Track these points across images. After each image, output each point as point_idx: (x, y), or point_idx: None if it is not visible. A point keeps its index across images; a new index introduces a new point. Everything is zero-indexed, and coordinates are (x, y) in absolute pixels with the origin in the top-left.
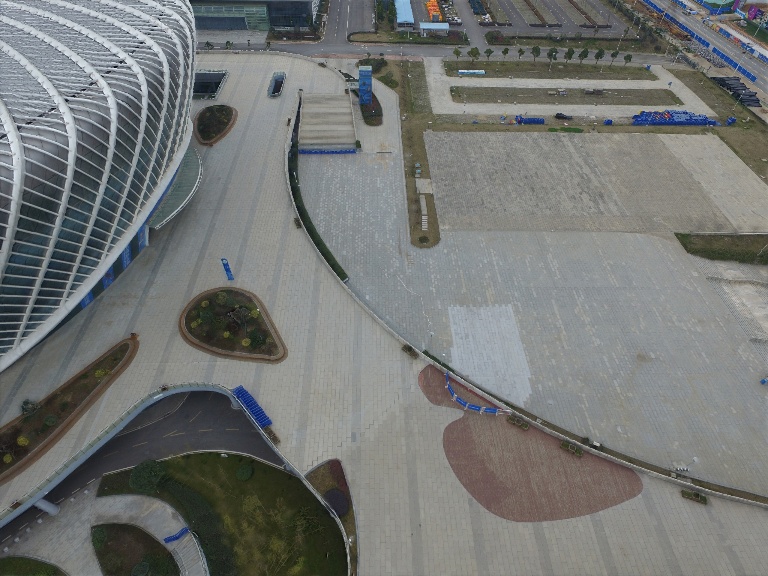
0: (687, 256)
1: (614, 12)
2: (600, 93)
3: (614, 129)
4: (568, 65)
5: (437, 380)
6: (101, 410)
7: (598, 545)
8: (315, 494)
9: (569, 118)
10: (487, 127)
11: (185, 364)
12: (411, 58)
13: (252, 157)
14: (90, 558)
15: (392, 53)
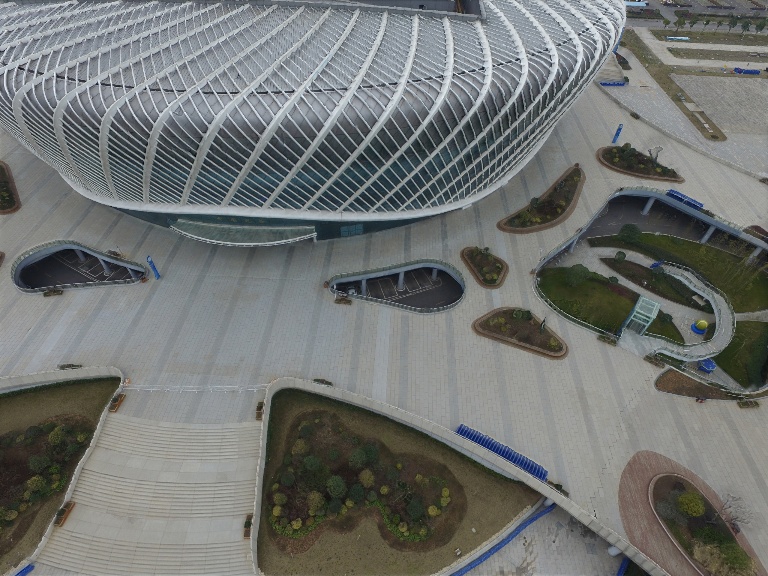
0: None
1: None
2: None
3: None
4: (756, 36)
5: None
6: (588, 197)
7: None
8: (755, 238)
9: None
10: (717, 74)
11: (621, 180)
12: None
13: None
14: (610, 271)
15: None
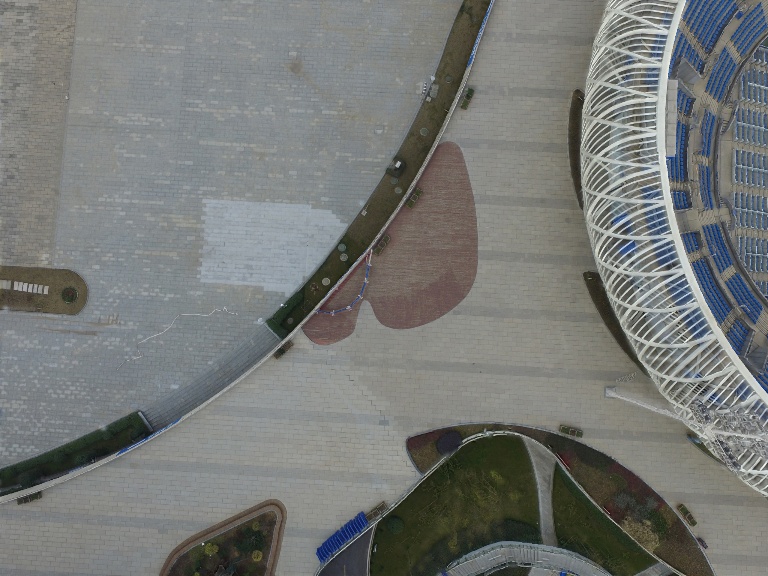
0: None
1: None
2: None
3: None
4: None
5: (323, 323)
6: None
7: (500, 206)
8: None
9: None
10: None
11: None
12: None
13: None
14: None
15: None
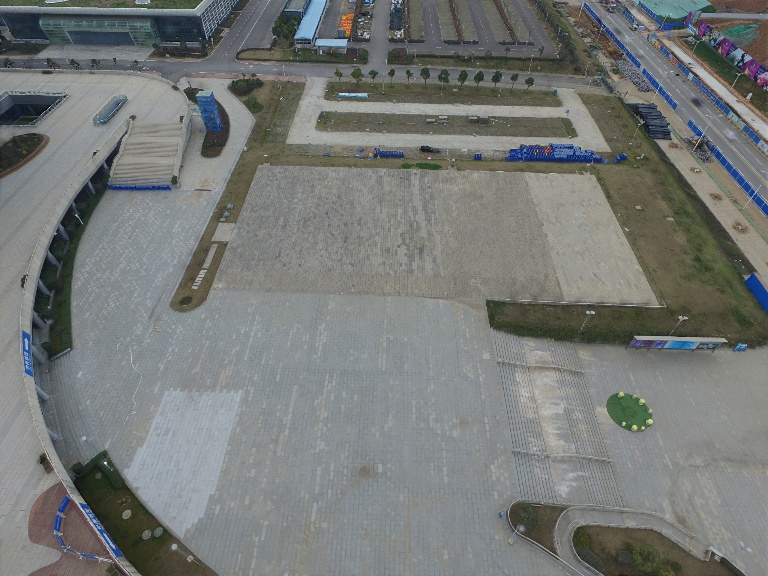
0: (487, 332)
1: (545, 27)
2: (485, 122)
3: (478, 166)
4: (464, 88)
5: (56, 505)
6: None
7: None
8: None
9: (435, 151)
10: (334, 161)
11: None
12: (294, 78)
13: (29, 196)
14: None
15: (276, 73)
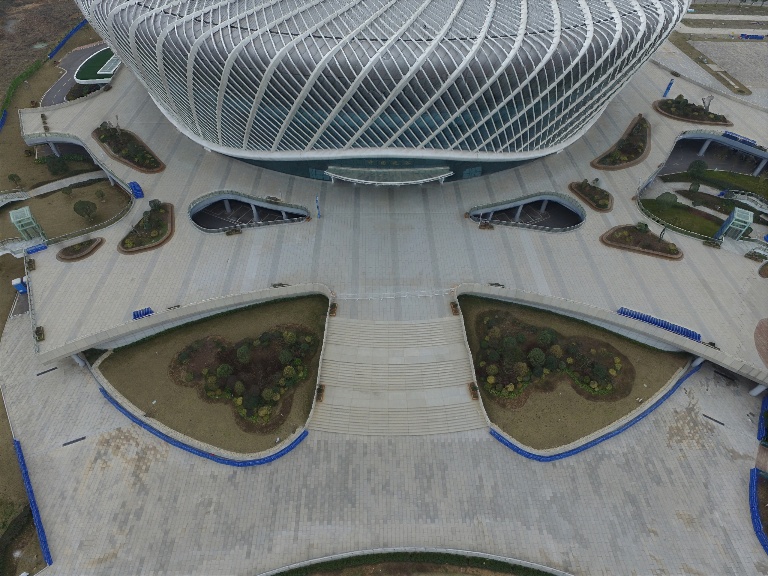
0: None
1: None
2: None
3: None
4: (752, 7)
5: None
6: (658, 140)
7: None
8: None
9: None
10: (728, 39)
11: (681, 126)
12: None
13: None
14: (686, 200)
15: None
